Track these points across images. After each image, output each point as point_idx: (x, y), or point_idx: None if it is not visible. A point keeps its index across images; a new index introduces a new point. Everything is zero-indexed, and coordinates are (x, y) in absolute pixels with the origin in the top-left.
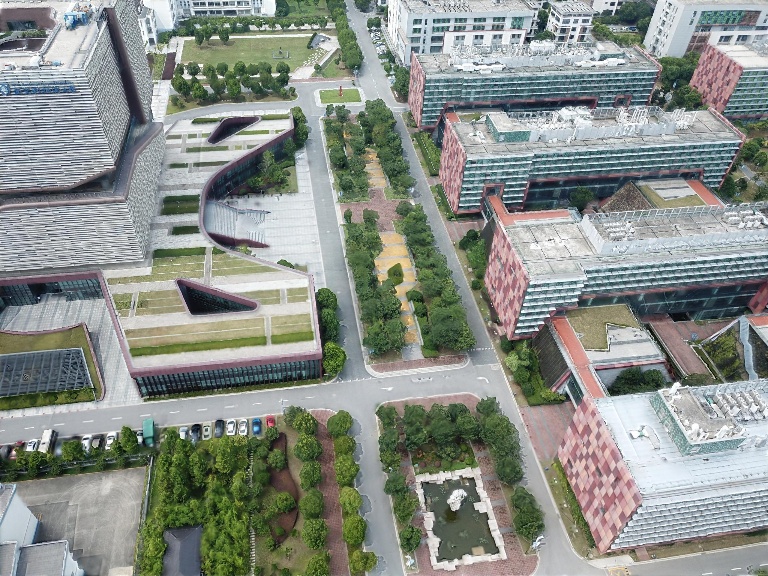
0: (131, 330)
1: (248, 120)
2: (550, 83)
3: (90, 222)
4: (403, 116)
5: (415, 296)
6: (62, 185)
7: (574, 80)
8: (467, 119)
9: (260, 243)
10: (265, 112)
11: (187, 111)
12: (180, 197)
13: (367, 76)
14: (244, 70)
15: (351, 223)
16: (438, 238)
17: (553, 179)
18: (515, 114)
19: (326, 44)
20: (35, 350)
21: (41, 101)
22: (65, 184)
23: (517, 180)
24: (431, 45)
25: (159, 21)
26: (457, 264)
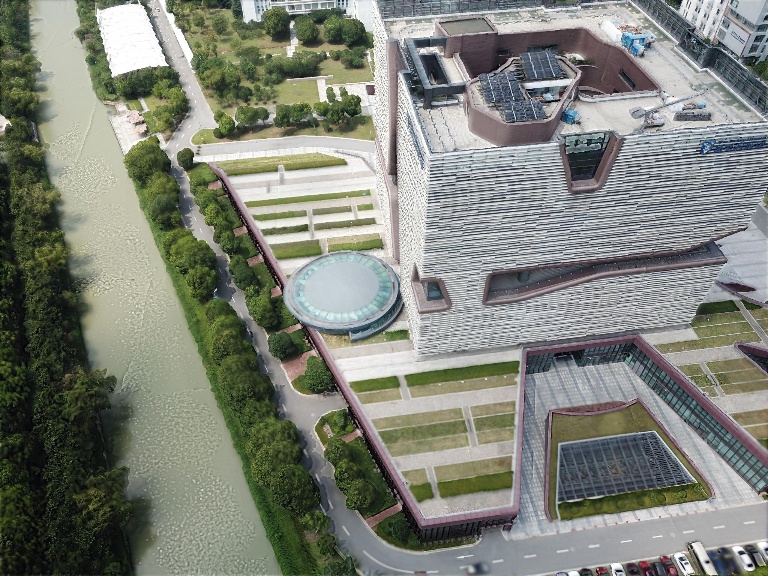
0: (737, 414)
1: None
2: None
3: (671, 286)
4: None
5: None
6: (677, 249)
7: None
8: None
9: (748, 287)
10: None
11: None
12: None
13: None
14: None
15: None
16: None
17: None
18: None
19: None
20: (604, 435)
21: (733, 158)
22: (681, 248)
23: None
24: None
25: None
26: None
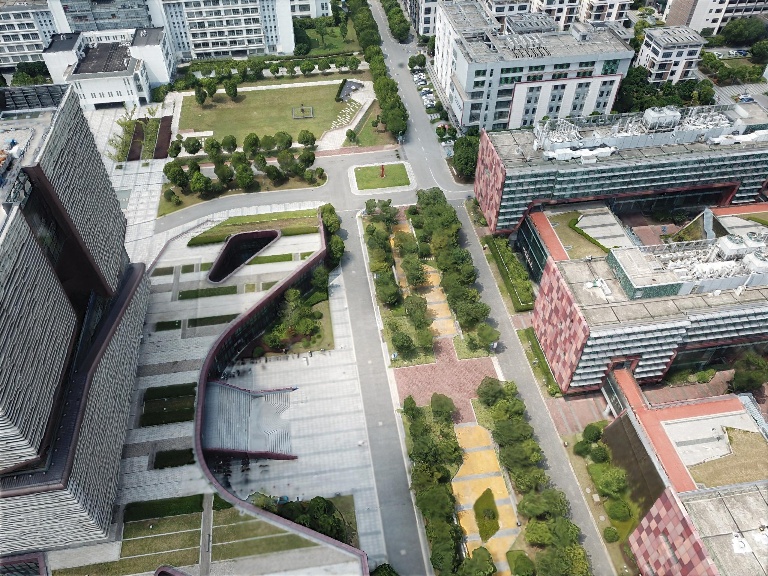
0: None
1: (263, 235)
2: (677, 170)
3: (14, 513)
4: (467, 207)
5: (523, 570)
6: None
7: (711, 165)
8: (561, 223)
9: (284, 455)
10: (285, 207)
11: (185, 209)
12: (168, 390)
13: (414, 142)
14: (257, 144)
15: (415, 420)
16: (540, 432)
17: (710, 344)
18: (651, 247)
19: (359, 94)
20: None
21: None
22: None
23: (659, 351)
24: (497, 100)
25: (151, 74)
26: (575, 486)
